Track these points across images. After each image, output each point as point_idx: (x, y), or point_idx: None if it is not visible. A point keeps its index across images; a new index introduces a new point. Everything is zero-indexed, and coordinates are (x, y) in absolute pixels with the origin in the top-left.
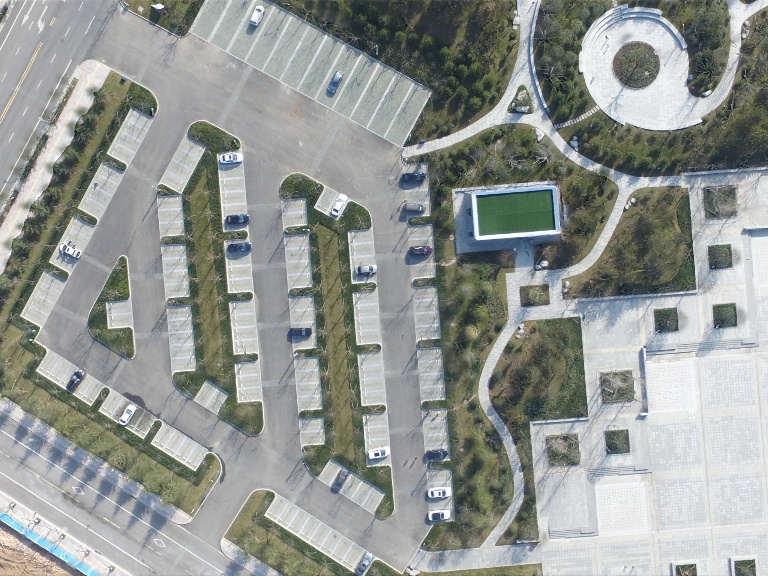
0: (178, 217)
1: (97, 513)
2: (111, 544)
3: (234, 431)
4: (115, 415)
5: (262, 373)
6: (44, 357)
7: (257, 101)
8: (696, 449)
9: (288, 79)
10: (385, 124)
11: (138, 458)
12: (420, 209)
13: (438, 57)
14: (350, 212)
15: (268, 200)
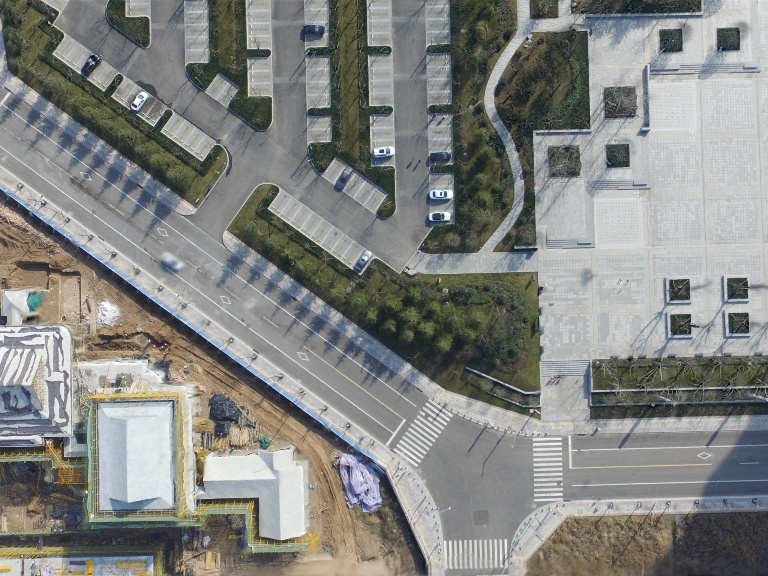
0: None
1: (103, 199)
2: (115, 231)
3: (243, 125)
4: (127, 102)
5: (274, 69)
6: (61, 41)
7: None
8: (694, 168)
9: None
10: None
11: (147, 143)
12: None
13: None
14: None
15: None
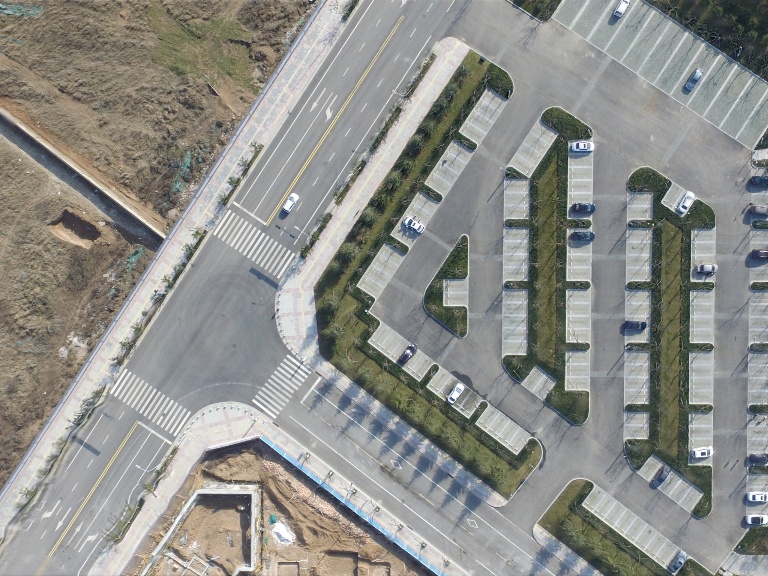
0: (524, 201)
1: (413, 488)
2: (424, 521)
3: (558, 418)
4: (442, 392)
5: (591, 363)
6: (377, 329)
7: (613, 92)
8: None
9: (646, 73)
10: (738, 125)
11: (464, 437)
12: (767, 213)
13: None
14: (697, 210)
15: (614, 191)
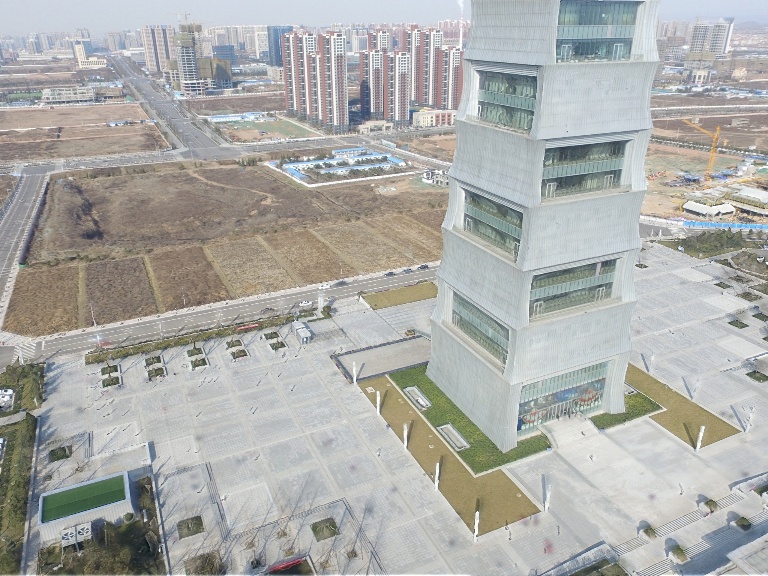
0: None
1: None
2: None
3: None
4: None
5: None
6: None
7: None
8: None
9: None
10: None
11: None
12: None
13: None
14: None
15: None
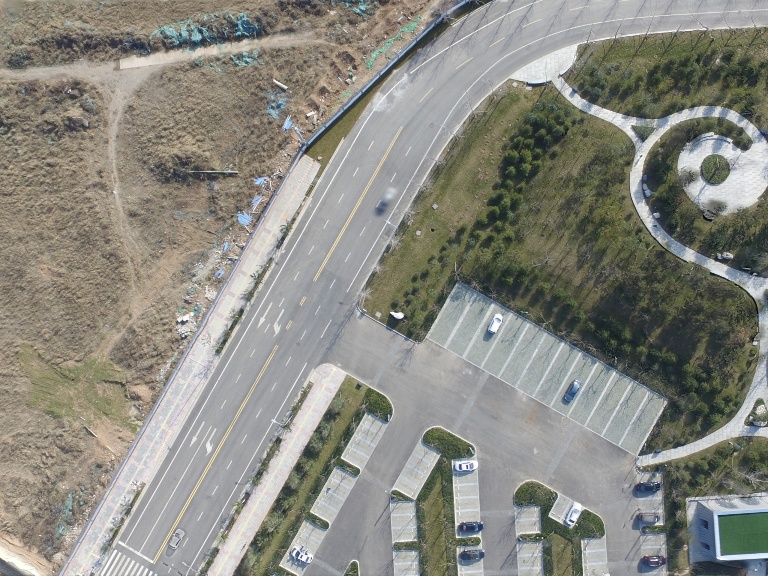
0: (411, 523)
1: None
2: None
3: None
4: None
5: None
6: None
7: (493, 408)
8: None
9: (524, 386)
10: (620, 432)
11: None
12: (656, 520)
13: (679, 372)
14: (585, 521)
15: (501, 506)
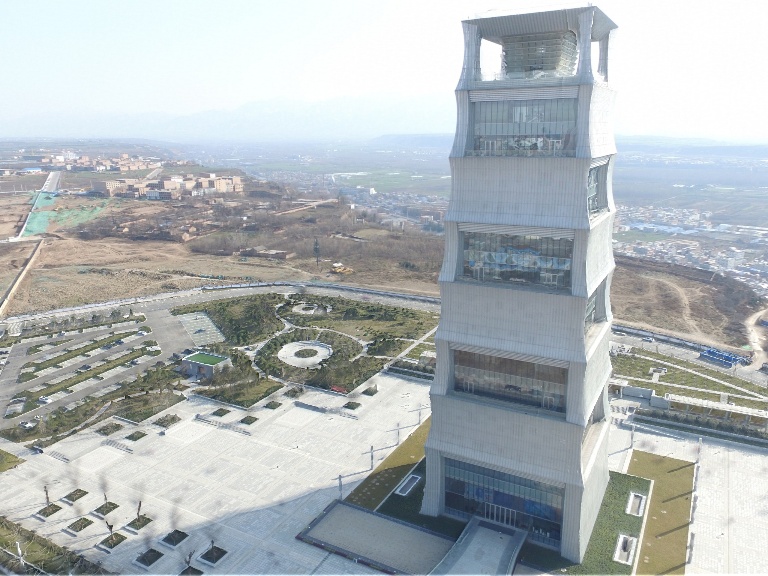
0: None
1: None
2: None
3: None
4: None
5: None
6: (8, 347)
7: None
8: None
9: None
10: None
11: None
12: (178, 356)
13: None
14: None
15: None
